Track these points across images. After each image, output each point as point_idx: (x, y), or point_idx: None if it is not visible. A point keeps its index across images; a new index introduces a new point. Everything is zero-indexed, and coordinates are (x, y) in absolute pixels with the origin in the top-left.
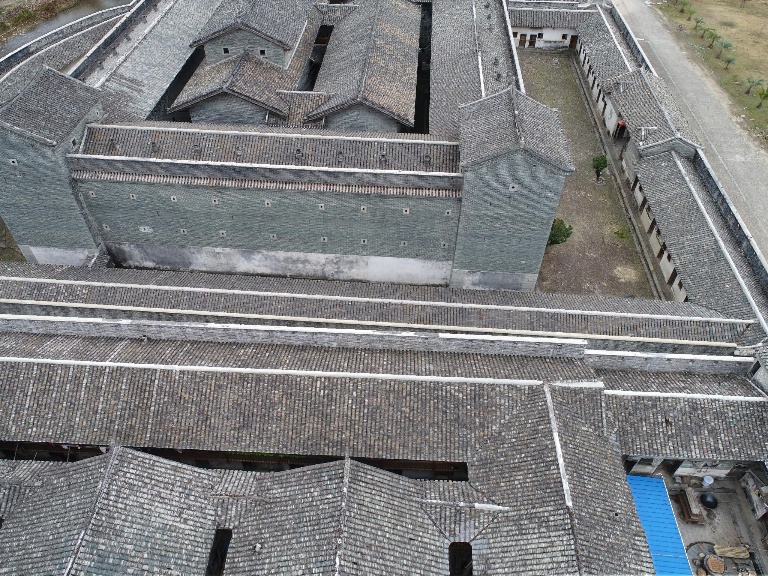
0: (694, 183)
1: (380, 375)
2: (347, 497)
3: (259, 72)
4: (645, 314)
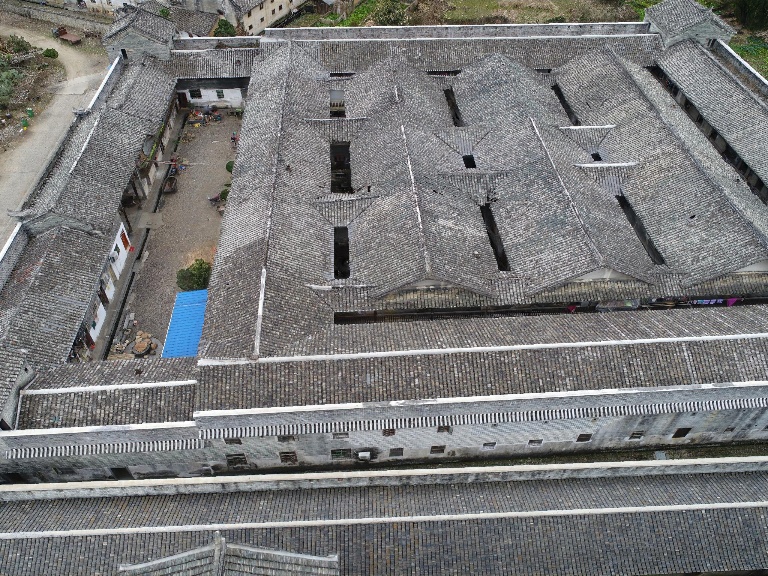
0: None
1: (419, 350)
2: None
3: None
4: (73, 533)
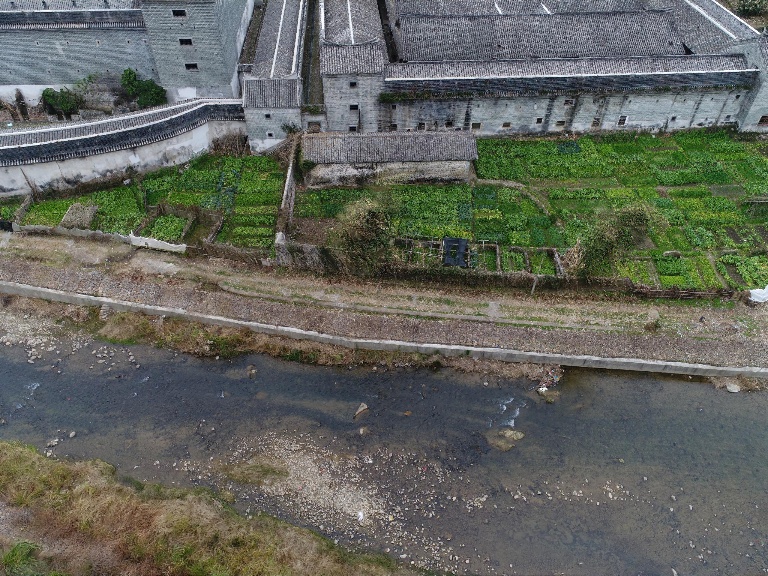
0: None
1: None
2: None
3: None
4: None
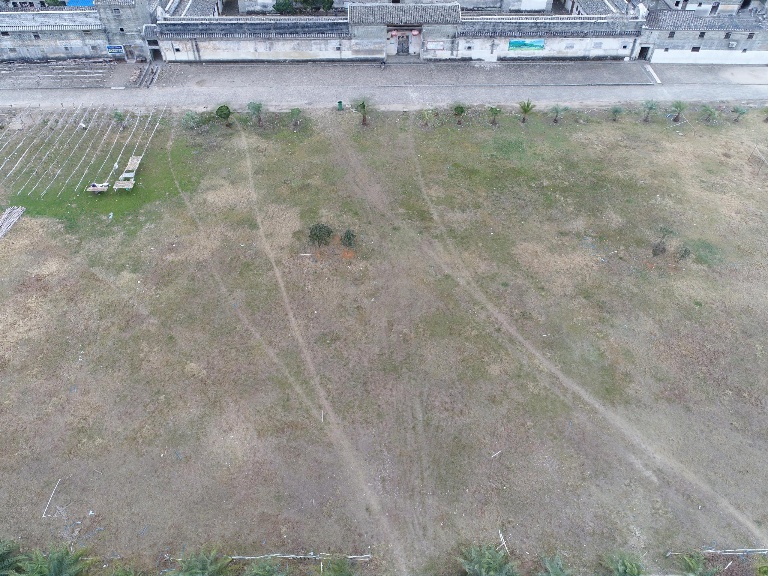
0: None
1: None
2: None
3: None
4: None
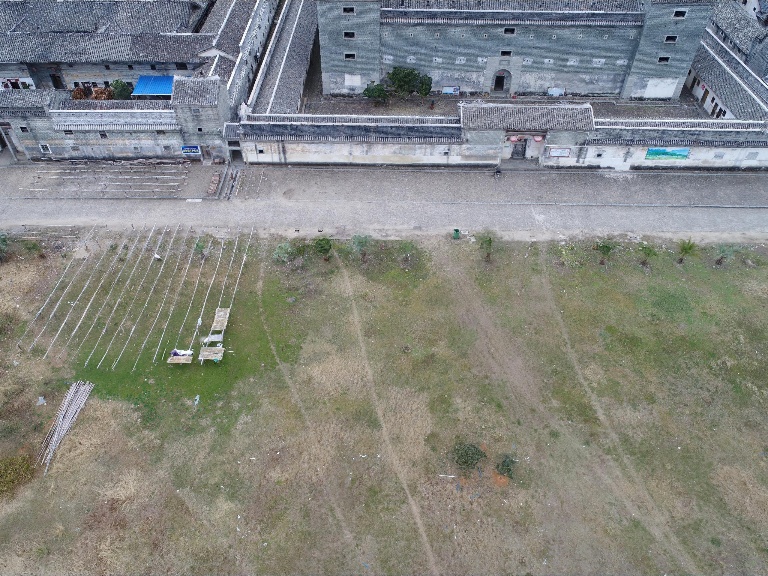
0: None
1: None
2: (177, 2)
3: None
4: None
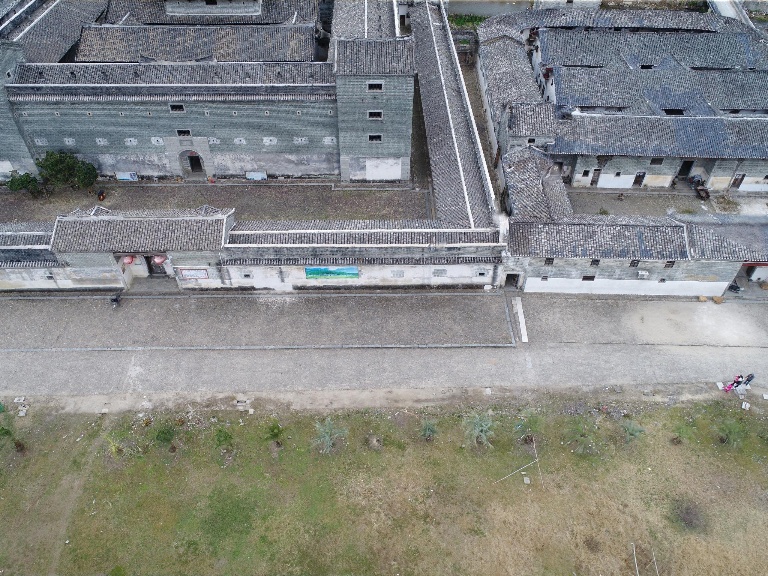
0: (8, 242)
1: None
2: None
3: (148, 2)
4: None
